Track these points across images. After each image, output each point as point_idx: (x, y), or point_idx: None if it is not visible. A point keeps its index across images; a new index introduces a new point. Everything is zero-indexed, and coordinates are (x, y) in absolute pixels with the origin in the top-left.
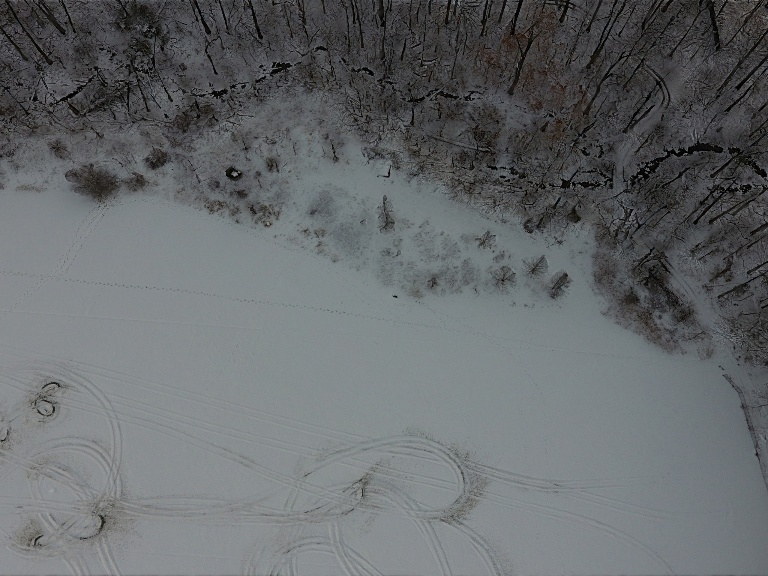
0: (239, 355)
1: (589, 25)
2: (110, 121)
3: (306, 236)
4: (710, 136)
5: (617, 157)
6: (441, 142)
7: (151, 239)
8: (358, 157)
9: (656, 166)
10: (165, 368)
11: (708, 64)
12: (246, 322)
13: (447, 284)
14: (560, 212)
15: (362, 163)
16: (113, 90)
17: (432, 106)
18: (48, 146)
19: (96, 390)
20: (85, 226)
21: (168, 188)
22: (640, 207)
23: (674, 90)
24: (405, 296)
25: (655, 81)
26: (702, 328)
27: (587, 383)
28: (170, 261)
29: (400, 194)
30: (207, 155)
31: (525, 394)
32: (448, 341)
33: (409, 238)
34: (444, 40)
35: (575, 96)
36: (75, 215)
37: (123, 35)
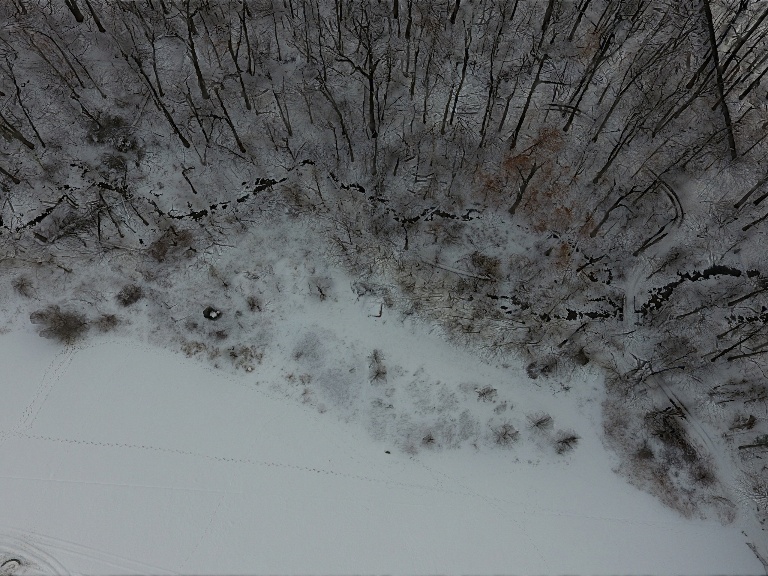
0: (217, 524)
1: (596, 135)
2: (80, 249)
3: (291, 383)
4: (727, 258)
5: (627, 284)
6: (437, 269)
7: (123, 387)
8: (347, 294)
9: (669, 292)
10: (136, 541)
11: (724, 176)
12: (225, 485)
13: (444, 439)
14: (566, 352)
15: (351, 300)
16: (84, 213)
17: (427, 229)
18: (11, 284)
19: (60, 568)
20: (51, 373)
21: (142, 328)
22: (653, 343)
23: (687, 205)
24: (398, 452)
25: (667, 195)
26: (722, 486)
27: (598, 554)
28: (143, 413)
29: (393, 336)
30: (184, 292)
31: (530, 568)
32: (445, 505)
33: (402, 387)
34: (440, 154)
35: (581, 214)
36: (41, 360)
37: (96, 149)
